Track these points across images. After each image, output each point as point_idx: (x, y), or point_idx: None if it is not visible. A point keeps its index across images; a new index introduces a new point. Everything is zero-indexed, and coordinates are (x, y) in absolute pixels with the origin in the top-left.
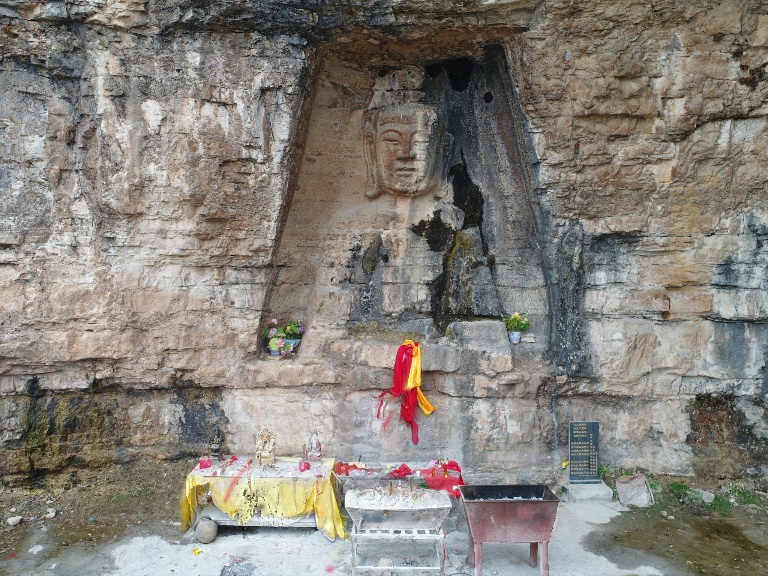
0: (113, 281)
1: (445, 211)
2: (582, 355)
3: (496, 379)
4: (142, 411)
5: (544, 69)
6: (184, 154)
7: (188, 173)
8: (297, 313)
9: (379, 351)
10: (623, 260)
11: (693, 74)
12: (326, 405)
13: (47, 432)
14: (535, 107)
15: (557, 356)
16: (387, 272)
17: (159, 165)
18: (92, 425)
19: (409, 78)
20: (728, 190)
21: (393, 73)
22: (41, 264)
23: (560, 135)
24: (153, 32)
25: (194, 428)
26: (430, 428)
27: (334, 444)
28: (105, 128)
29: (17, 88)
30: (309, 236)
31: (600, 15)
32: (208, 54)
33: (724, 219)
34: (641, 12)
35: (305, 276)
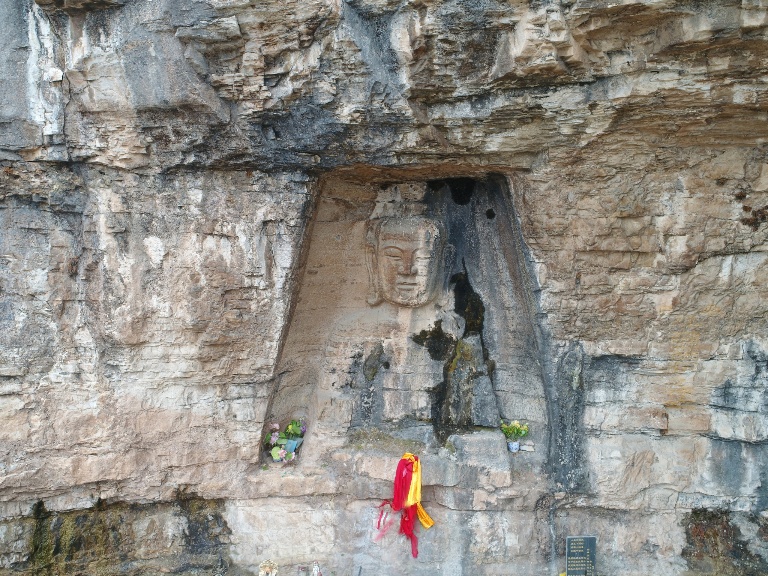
0: (117, 405)
1: (446, 321)
2: (580, 474)
3: (495, 494)
4: (146, 525)
5: (546, 208)
6: (186, 286)
7: (190, 304)
8: (299, 411)
9: (380, 463)
10: (622, 379)
11: (695, 214)
12: (327, 515)
13: (53, 552)
14: (537, 241)
15: (556, 472)
16: (388, 378)
17: (161, 297)
18: (97, 542)
19: (411, 191)
20: (728, 318)
21: (395, 186)
22: (45, 393)
23: (561, 268)
24: (155, 171)
25: (197, 540)
26: (430, 541)
27: (335, 554)
28: (107, 263)
29: (19, 225)
30: (311, 341)
31: (603, 163)
32: (210, 191)
33: (723, 345)
34: (644, 161)
35: (307, 376)
